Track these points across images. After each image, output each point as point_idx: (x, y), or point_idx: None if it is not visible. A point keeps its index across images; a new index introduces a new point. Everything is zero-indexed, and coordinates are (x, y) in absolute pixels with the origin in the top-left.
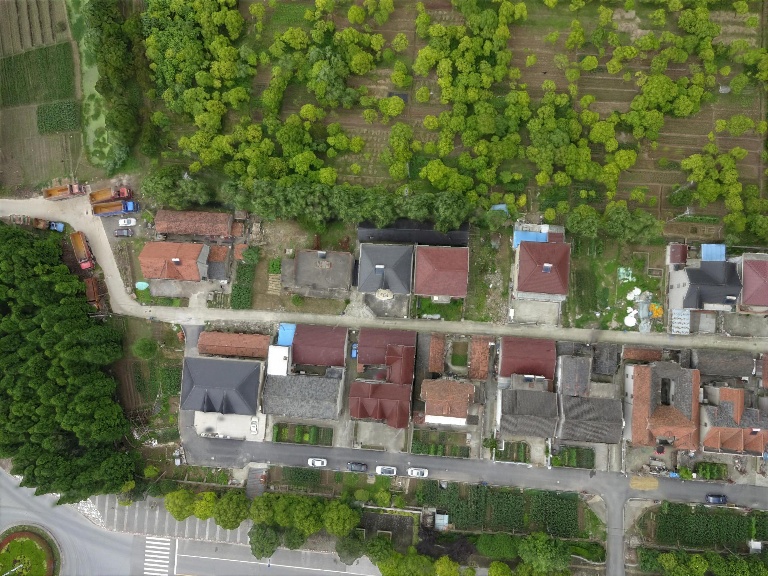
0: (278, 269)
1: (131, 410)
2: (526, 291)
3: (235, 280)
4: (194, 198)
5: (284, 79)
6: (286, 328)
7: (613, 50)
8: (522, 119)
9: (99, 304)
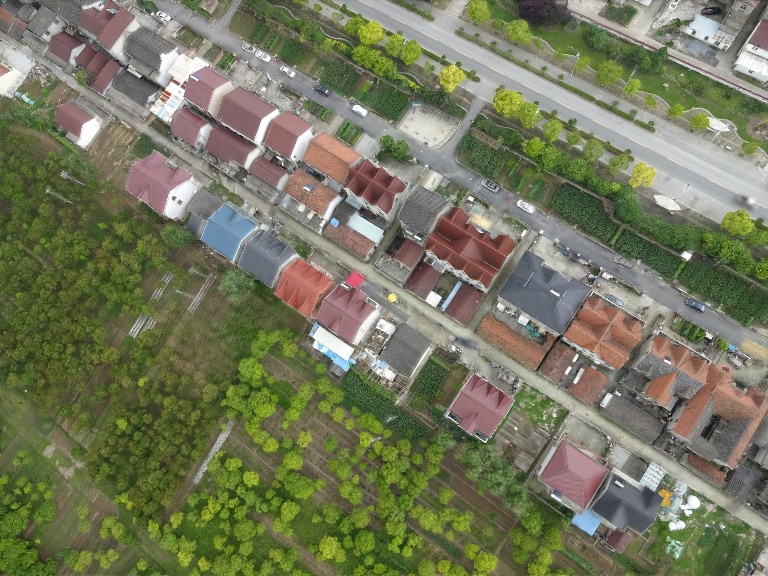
0: None
1: None
2: None
3: None
4: None
5: None
6: None
7: None
8: None
9: None
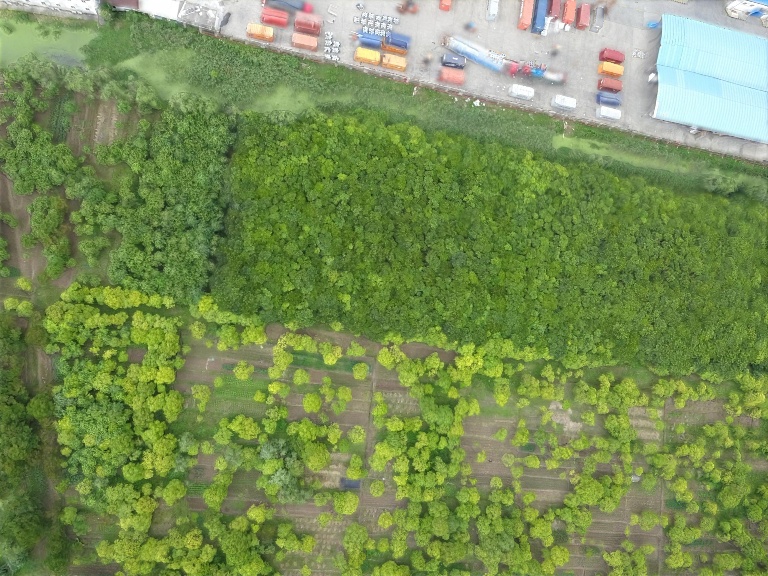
0: None
1: None
2: None
3: None
4: None
5: (230, 473)
6: None
7: (552, 450)
8: (472, 517)
9: None
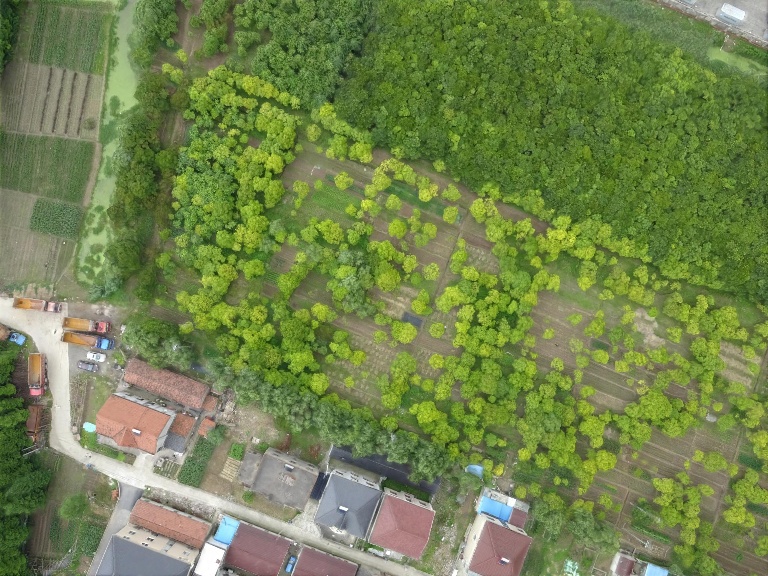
0: (239, 456)
1: (36, 556)
2: (476, 572)
3: (191, 452)
4: (176, 364)
5: (306, 268)
6: (228, 523)
7: (626, 352)
8: (523, 389)
9: (37, 436)
